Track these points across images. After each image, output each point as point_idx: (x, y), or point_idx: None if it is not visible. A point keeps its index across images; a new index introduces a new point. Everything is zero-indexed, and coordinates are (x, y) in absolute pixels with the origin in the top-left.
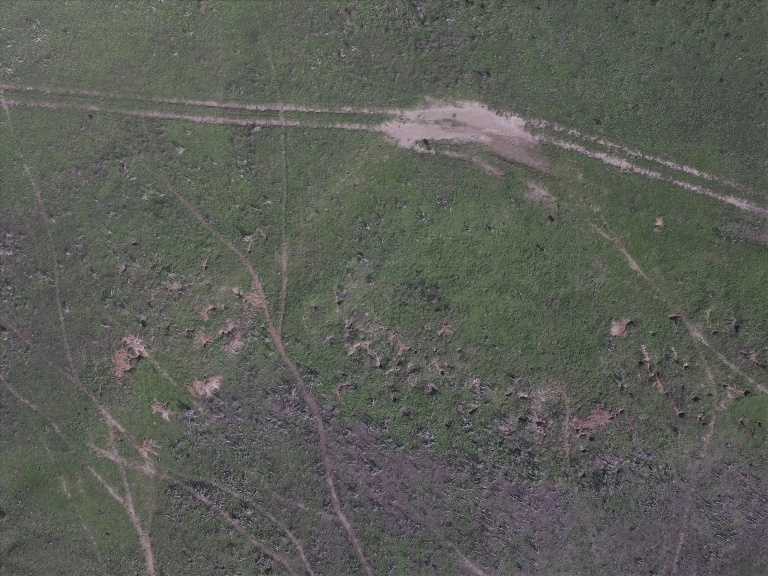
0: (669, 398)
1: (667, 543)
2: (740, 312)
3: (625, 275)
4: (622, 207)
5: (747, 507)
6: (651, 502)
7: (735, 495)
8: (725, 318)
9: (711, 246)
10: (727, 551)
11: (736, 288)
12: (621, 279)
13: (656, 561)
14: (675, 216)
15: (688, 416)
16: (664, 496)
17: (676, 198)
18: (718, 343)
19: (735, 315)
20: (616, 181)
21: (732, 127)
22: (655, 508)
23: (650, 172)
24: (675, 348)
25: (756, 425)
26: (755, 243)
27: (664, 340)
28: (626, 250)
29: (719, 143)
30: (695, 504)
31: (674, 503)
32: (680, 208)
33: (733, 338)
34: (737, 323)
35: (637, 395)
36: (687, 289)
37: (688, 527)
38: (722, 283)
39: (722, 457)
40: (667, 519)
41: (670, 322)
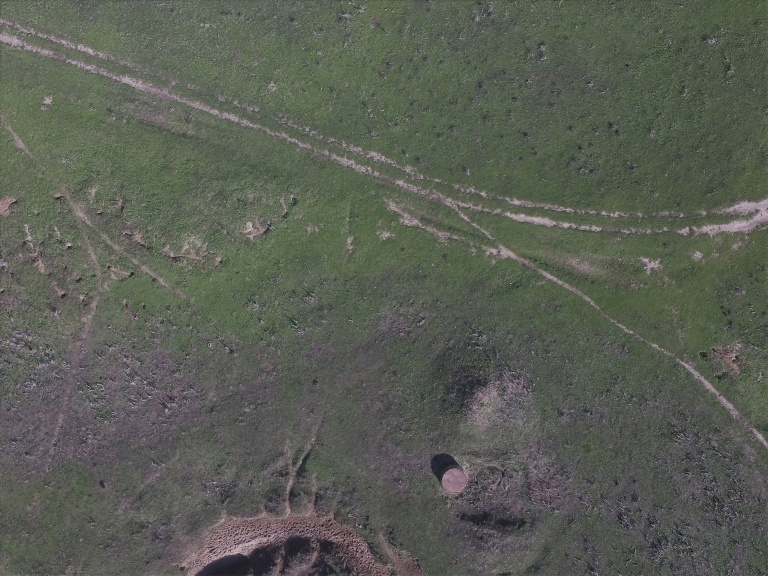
0: (50, 278)
1: (45, 425)
2: (124, 192)
3: (10, 153)
4: (10, 85)
5: (129, 390)
6: (29, 383)
7: (117, 377)
8: (110, 198)
9: (100, 126)
10: (106, 433)
11: (121, 168)
12: (6, 157)
13: (33, 442)
14: (66, 95)
15: (69, 297)
16: (44, 377)
17: (68, 77)
18: (101, 223)
19: (120, 195)
20: (6, 58)
21: (131, 6)
22: (34, 389)
23: (42, 50)
24: (58, 228)
25: (138, 307)
26: (150, 124)
27: (47, 220)
28: (12, 128)
29: (116, 22)
30: (76, 386)
31: (54, 385)
32: (71, 87)
33: (117, 219)
34: (122, 204)
35: (16, 275)
36: (71, 168)
37: (68, 409)
38: (108, 163)
39: (104, 339)
40: (46, 401)
41: (54, 202)
